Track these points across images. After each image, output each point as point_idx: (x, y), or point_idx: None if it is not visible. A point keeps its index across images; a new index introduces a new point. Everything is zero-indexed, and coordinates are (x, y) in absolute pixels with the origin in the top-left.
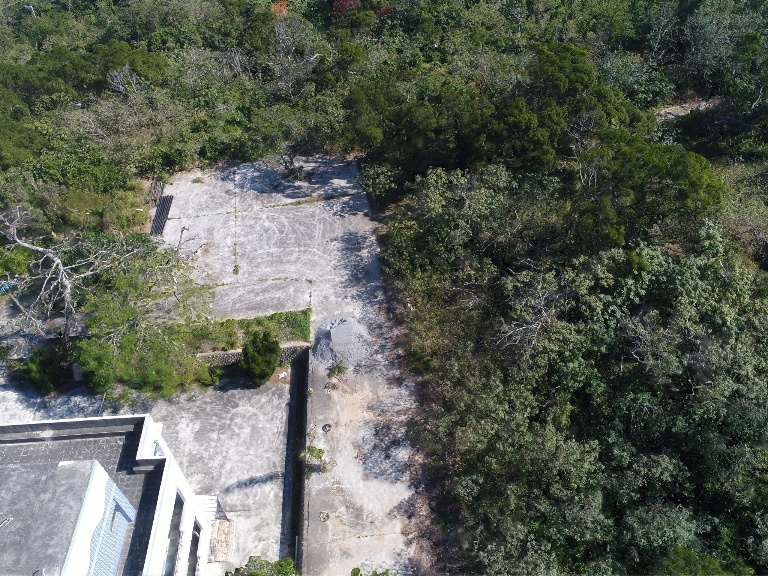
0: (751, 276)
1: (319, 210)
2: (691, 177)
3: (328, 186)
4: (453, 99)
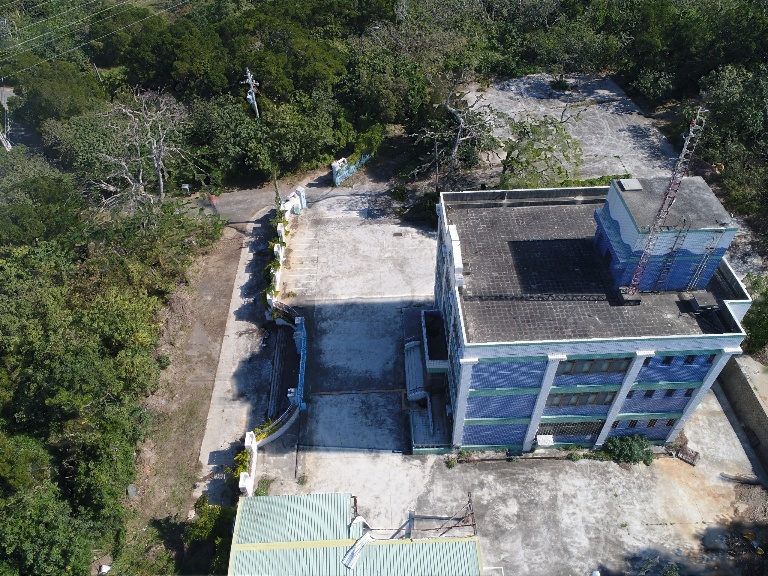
0: None
1: (597, 110)
2: None
3: (595, 94)
4: (737, 11)
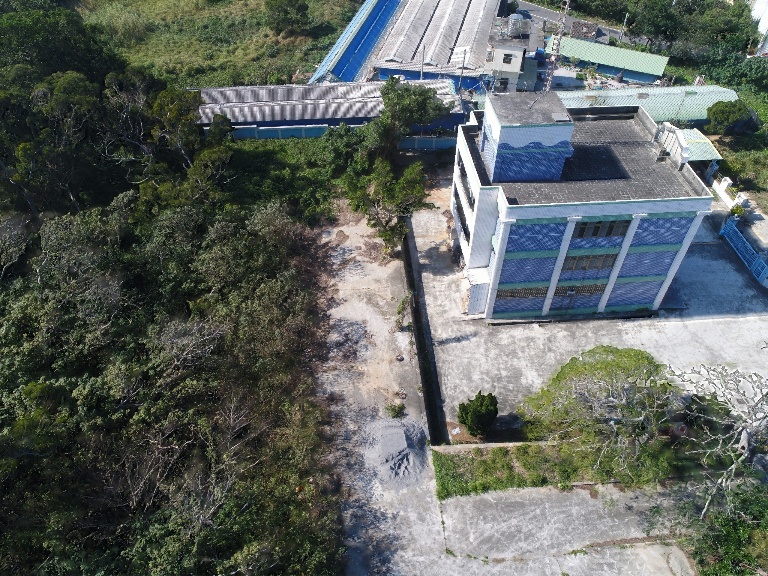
0: None
1: None
2: None
3: None
4: None
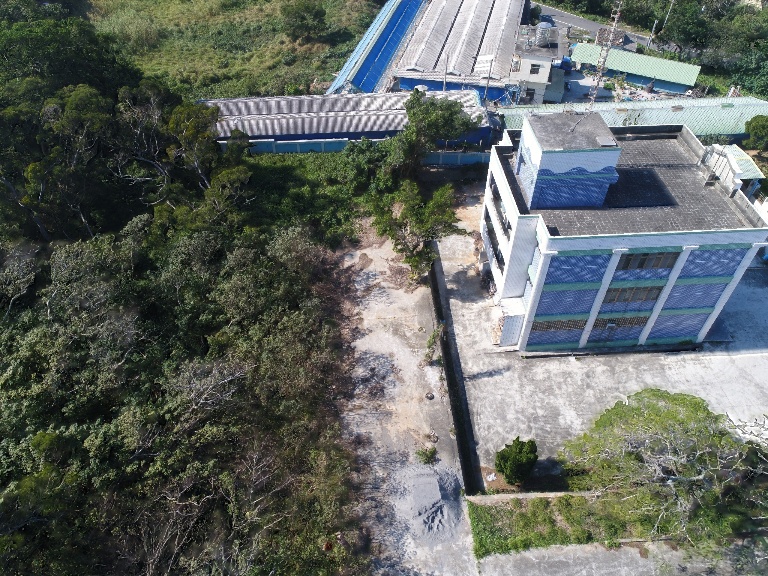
0: None
1: None
2: None
3: None
4: None
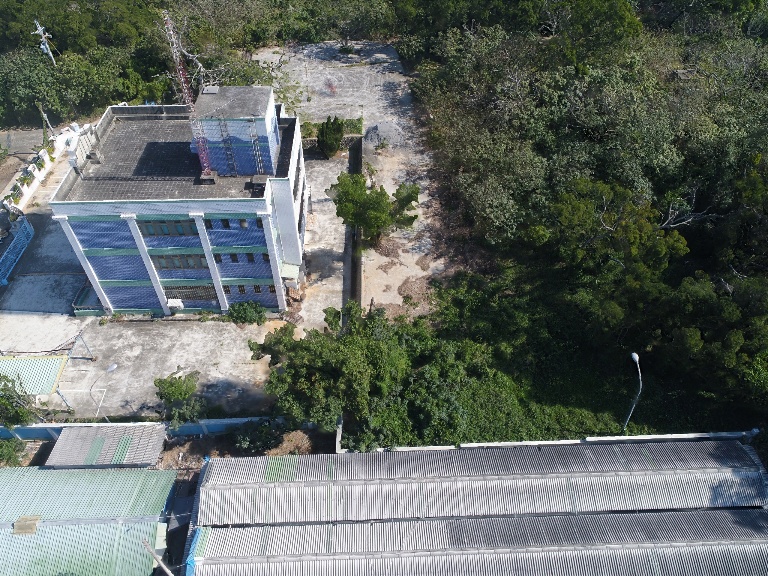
0: (655, 79)
1: (367, 70)
2: (619, 14)
3: (373, 57)
4: None
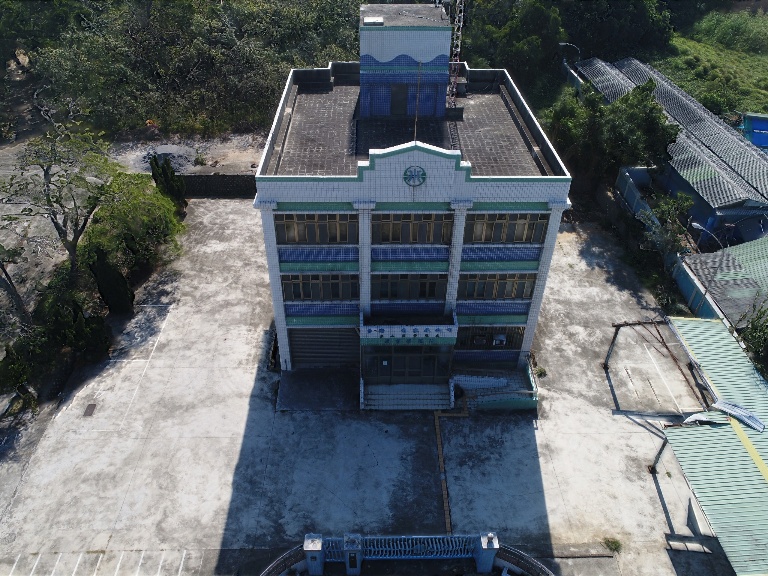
0: None
1: None
2: None
3: None
4: None
